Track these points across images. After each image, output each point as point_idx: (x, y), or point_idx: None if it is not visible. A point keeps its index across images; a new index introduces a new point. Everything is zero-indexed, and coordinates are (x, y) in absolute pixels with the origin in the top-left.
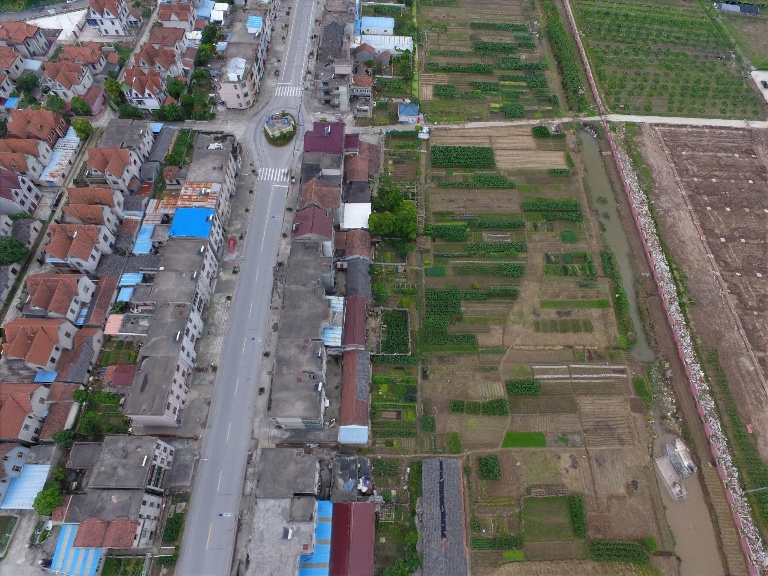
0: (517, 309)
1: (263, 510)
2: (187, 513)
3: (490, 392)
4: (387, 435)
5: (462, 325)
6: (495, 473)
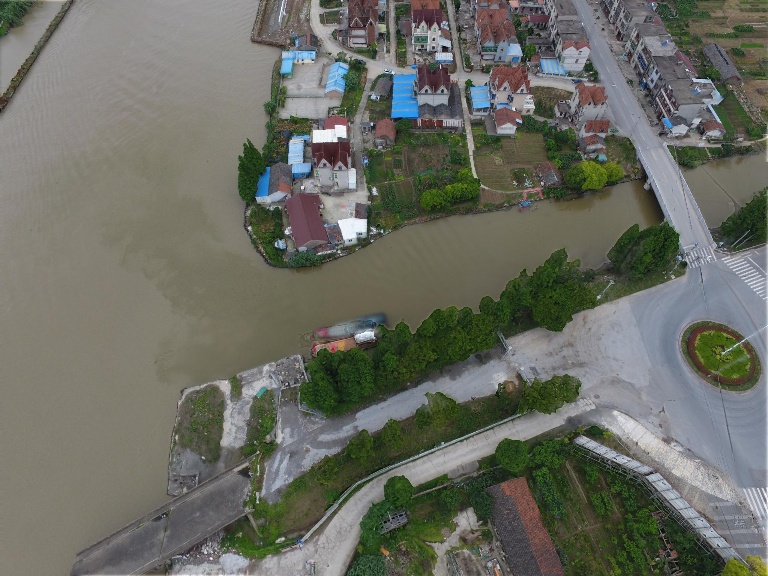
0: (727, 4)
1: (647, 39)
2: (592, 63)
3: (726, 31)
4: (678, 43)
5: (699, 10)
6: (743, 52)
